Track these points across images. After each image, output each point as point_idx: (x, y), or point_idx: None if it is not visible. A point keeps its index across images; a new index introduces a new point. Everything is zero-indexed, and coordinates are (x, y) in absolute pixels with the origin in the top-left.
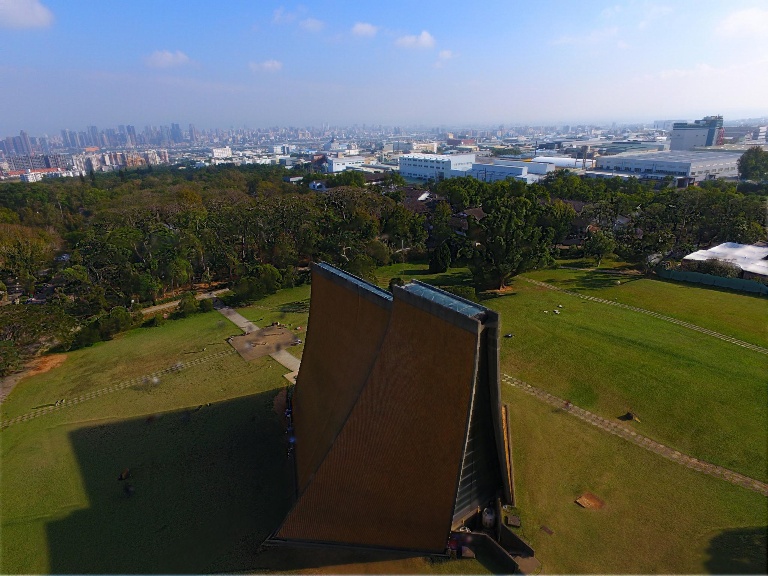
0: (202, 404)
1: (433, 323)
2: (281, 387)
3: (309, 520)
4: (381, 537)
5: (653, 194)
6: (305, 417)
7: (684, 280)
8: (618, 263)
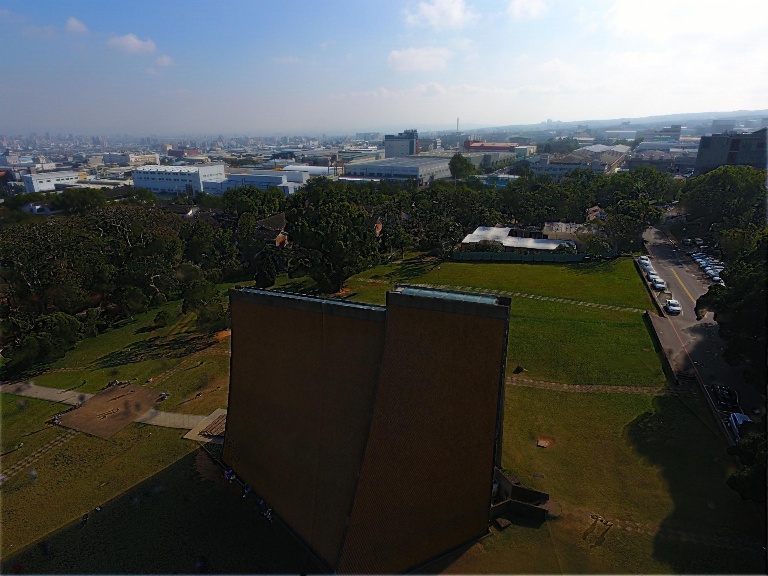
0: (86, 512)
1: (448, 320)
2: (193, 451)
3: (360, 569)
4: (434, 547)
5: (409, 194)
6: (271, 468)
7: (471, 259)
8: (416, 253)
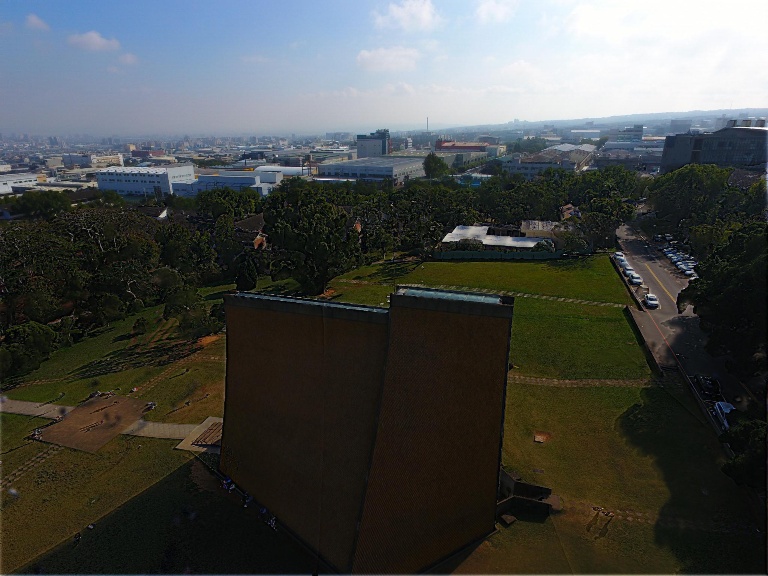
0: (77, 531)
1: (453, 320)
2: (187, 461)
3: (372, 573)
4: (443, 547)
5: (386, 194)
6: (273, 476)
7: (452, 258)
8: None
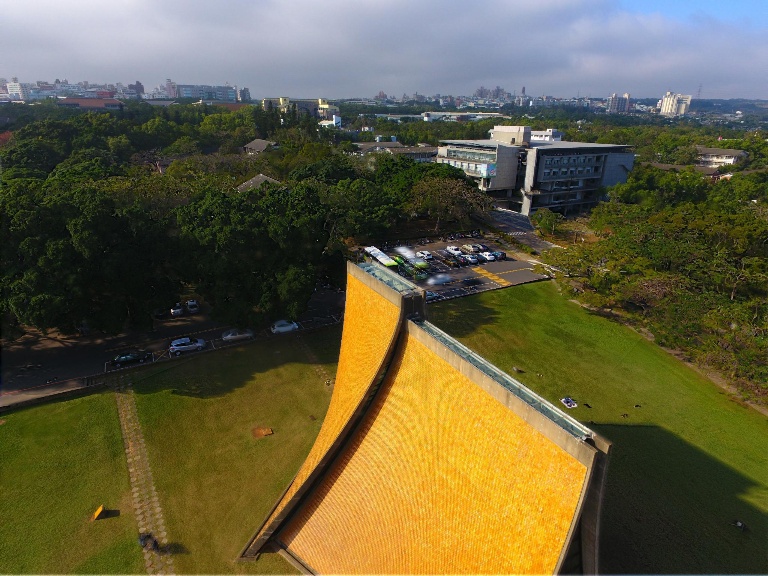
0: None
1: None
2: None
3: None
4: None
5: None
6: None
7: None
8: None
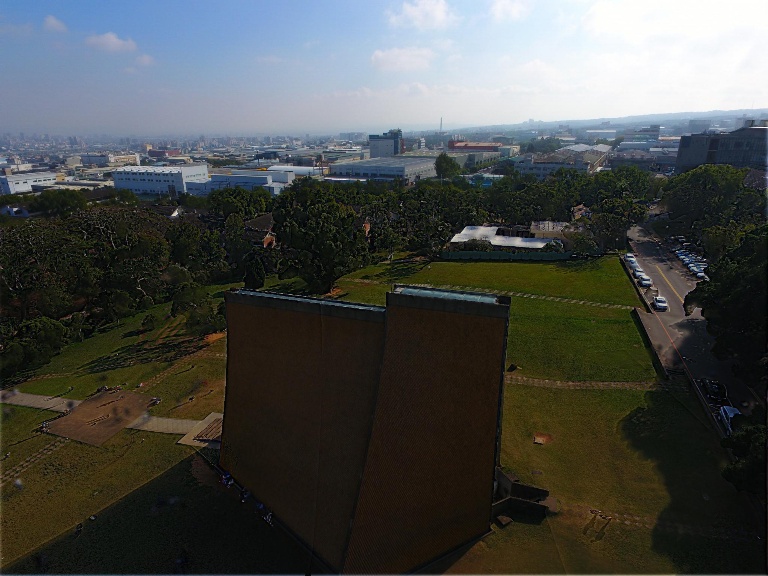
0: (79, 522)
1: (449, 320)
2: (188, 456)
3: (364, 570)
4: (437, 547)
5: (396, 193)
6: (270, 472)
7: (460, 258)
8: (405, 253)
